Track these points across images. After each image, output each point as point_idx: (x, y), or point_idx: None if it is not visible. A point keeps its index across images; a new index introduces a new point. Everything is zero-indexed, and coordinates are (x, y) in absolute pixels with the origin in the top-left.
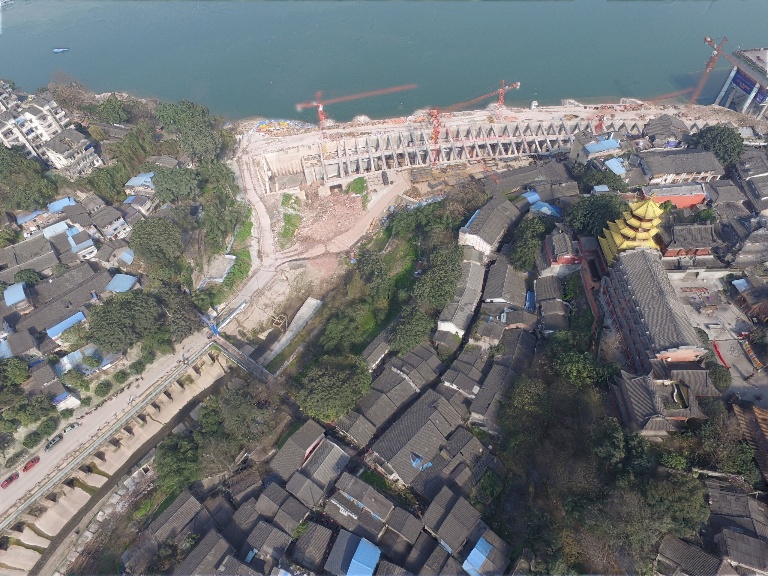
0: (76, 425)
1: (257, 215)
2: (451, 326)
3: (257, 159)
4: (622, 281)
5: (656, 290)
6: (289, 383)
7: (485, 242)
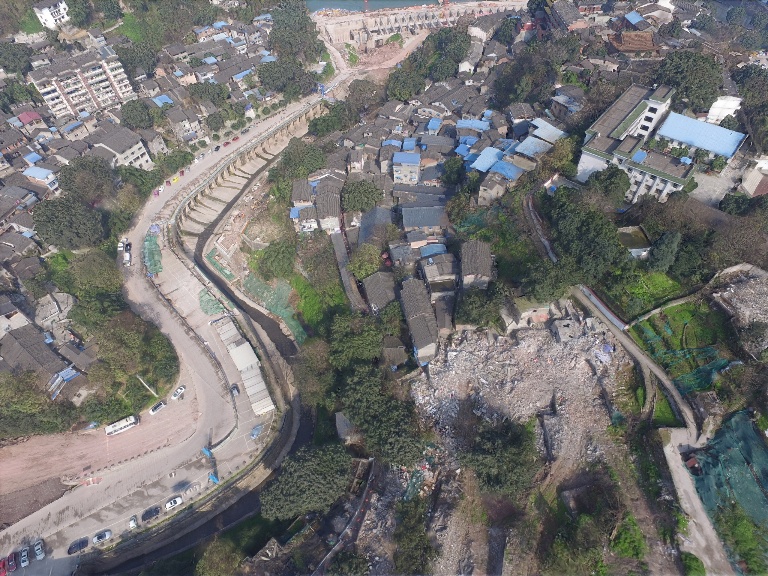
0: (255, 126)
1: (331, 52)
2: (467, 65)
3: (321, 29)
4: (555, 14)
5: (569, 8)
6: (375, 103)
7: (483, 31)
